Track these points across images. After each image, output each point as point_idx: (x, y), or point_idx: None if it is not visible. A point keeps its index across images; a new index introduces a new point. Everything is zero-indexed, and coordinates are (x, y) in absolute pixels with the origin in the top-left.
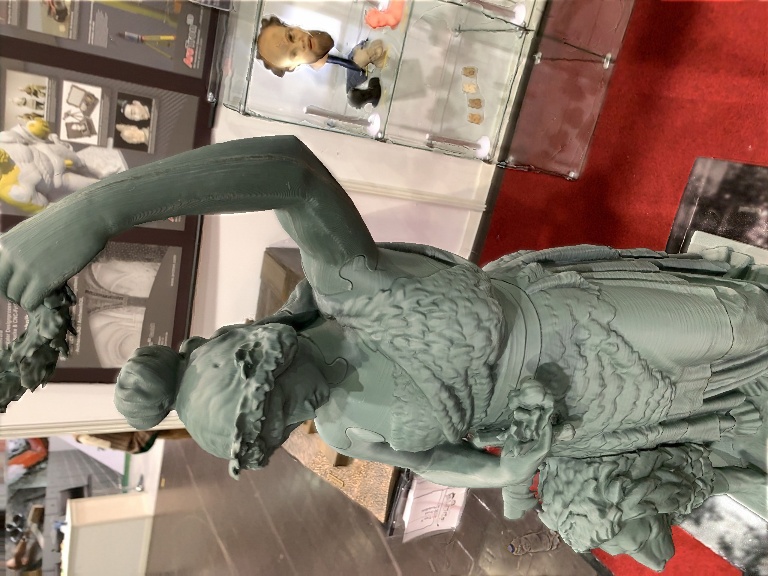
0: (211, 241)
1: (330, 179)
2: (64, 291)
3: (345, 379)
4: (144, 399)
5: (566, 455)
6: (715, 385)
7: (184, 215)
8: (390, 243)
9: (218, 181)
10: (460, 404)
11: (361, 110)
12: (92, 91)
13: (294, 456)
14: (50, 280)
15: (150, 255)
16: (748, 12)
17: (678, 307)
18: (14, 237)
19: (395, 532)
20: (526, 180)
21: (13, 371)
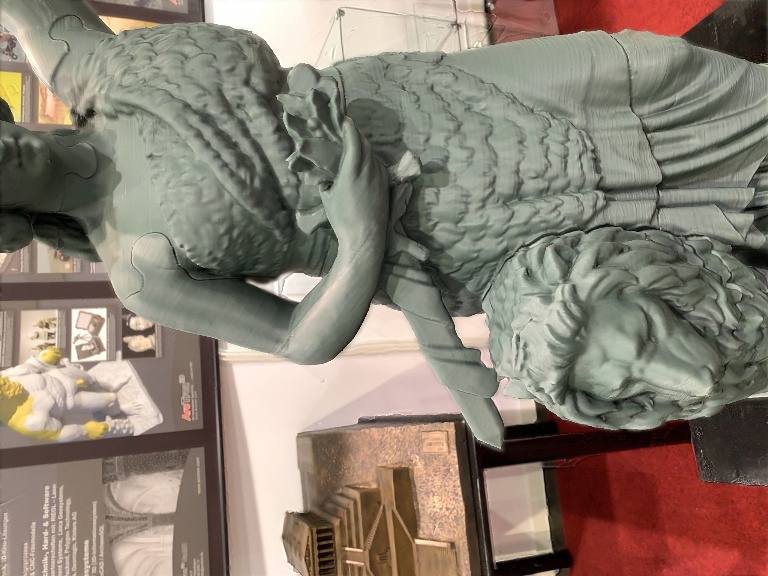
0: (237, 438)
1: None
2: None
3: (99, 173)
4: None
5: (468, 250)
6: (669, 150)
7: (201, 412)
8: None
9: None
10: (237, 148)
11: None
12: (98, 313)
13: None
14: None
15: (171, 462)
16: None
17: None
18: None
19: None
20: None
21: None
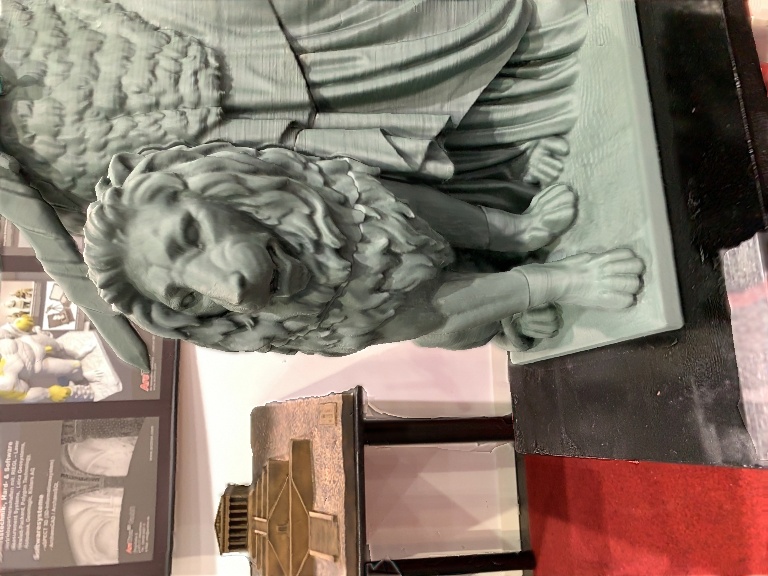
0: (195, 411)
1: None
2: None
3: None
4: None
5: (72, 164)
6: (330, 71)
7: (159, 383)
8: None
9: None
10: None
11: None
12: None
13: None
14: None
15: (127, 429)
16: None
17: None
18: None
19: None
20: None
21: None
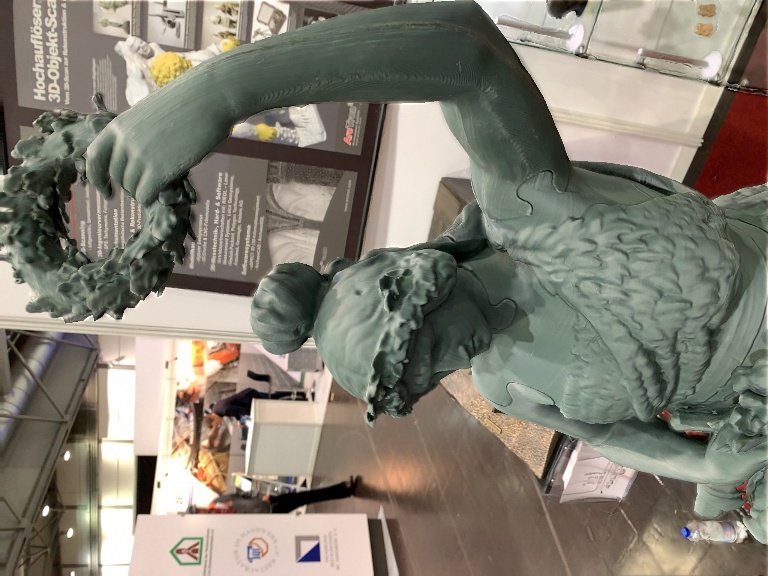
0: (386, 167)
1: (516, 63)
2: (182, 186)
3: (512, 325)
4: (278, 322)
5: None
6: None
7: (361, 139)
8: (587, 162)
9: (367, 55)
10: (660, 374)
11: (562, 20)
12: (281, 7)
13: (452, 395)
14: (164, 170)
15: (327, 179)
16: None
17: None
18: (129, 117)
19: (552, 491)
20: (762, 109)
21: (124, 274)
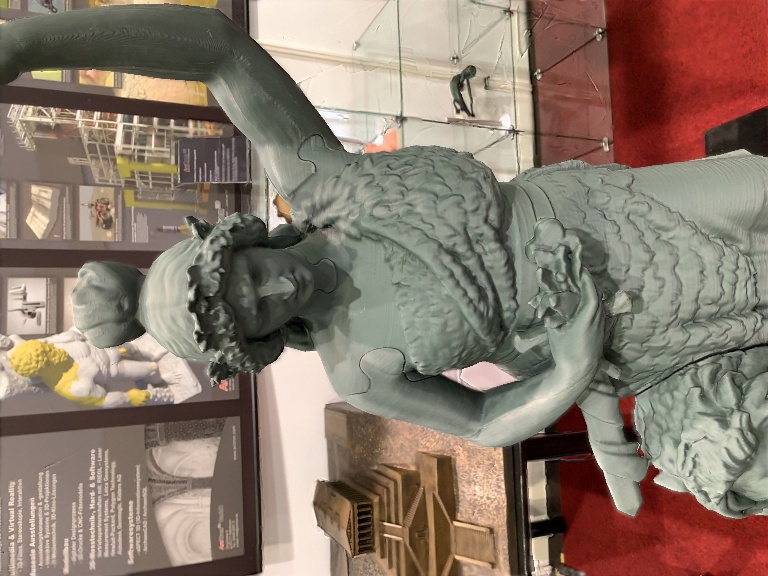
0: (269, 407)
1: (261, 48)
2: None
3: (338, 287)
4: (97, 293)
5: (647, 365)
6: None
7: (237, 382)
8: None
9: (130, 16)
10: (474, 281)
11: None
12: None
13: None
14: None
15: (209, 430)
16: (714, 50)
17: (706, 163)
18: None
19: None
20: None
21: None
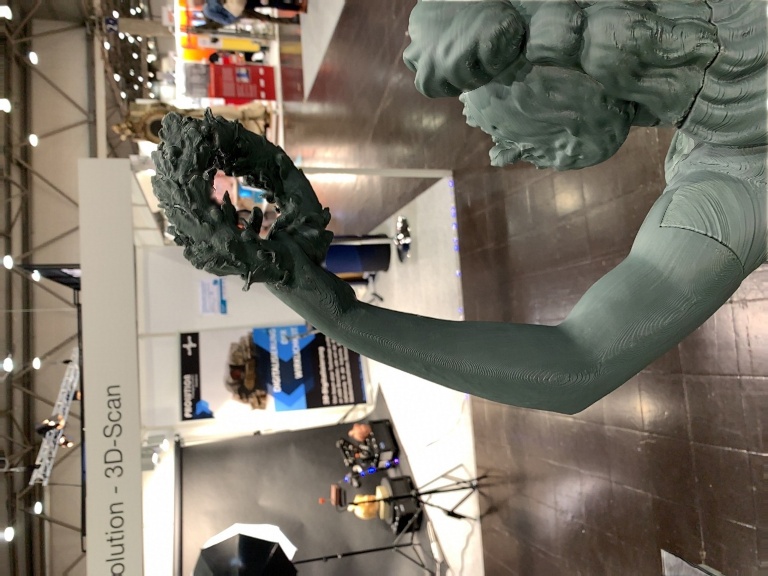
0: None
1: None
2: None
3: None
4: None
5: None
6: None
7: None
8: None
9: None
10: None
11: None
12: None
13: None
14: None
15: None
16: None
17: None
18: None
19: None
20: None
21: None
